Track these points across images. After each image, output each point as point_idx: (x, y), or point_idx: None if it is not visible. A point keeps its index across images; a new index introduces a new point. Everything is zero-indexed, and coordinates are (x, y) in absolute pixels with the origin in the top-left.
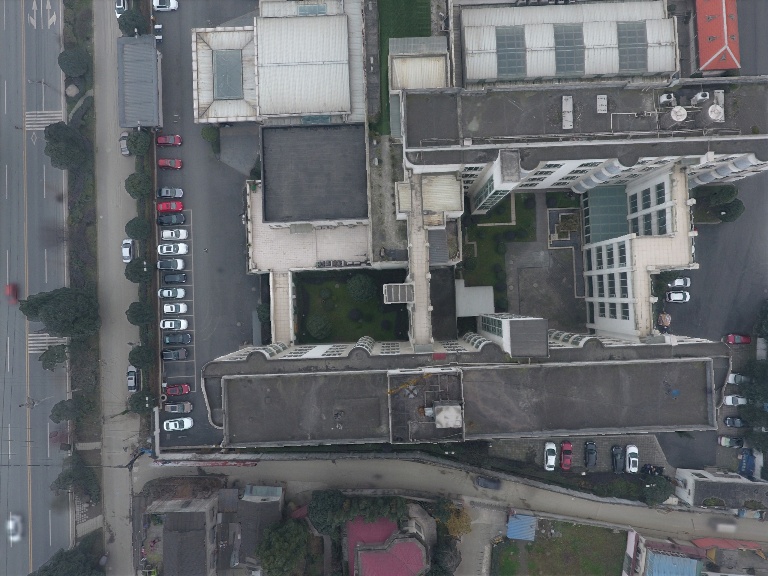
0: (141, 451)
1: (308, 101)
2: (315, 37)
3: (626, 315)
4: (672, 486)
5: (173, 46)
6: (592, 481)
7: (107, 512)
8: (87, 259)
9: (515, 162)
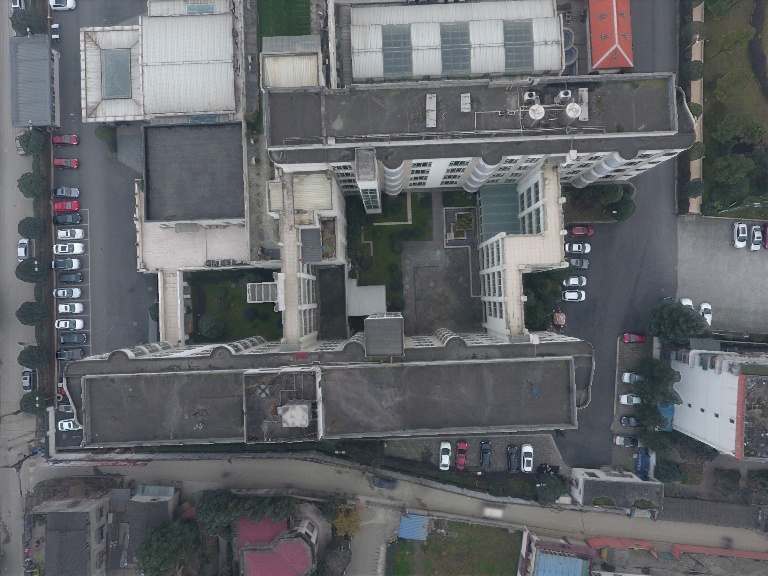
0: (34, 451)
1: None
2: (200, 36)
3: (501, 314)
4: (568, 485)
5: (71, 45)
6: (487, 480)
7: (3, 512)
8: None
9: (371, 161)
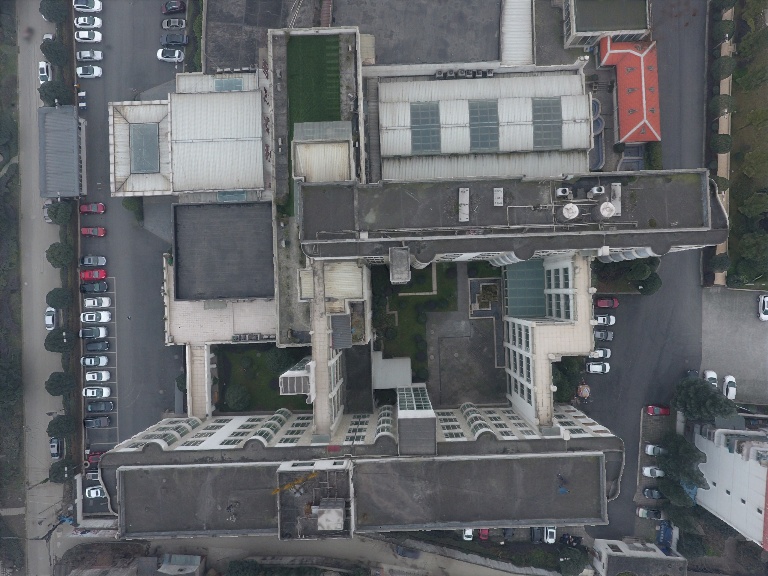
0: (62, 519)
1: (222, 177)
2: (229, 113)
3: (530, 400)
4: (590, 556)
5: (97, 113)
6: (510, 551)
7: None
8: (11, 326)
9: (405, 260)
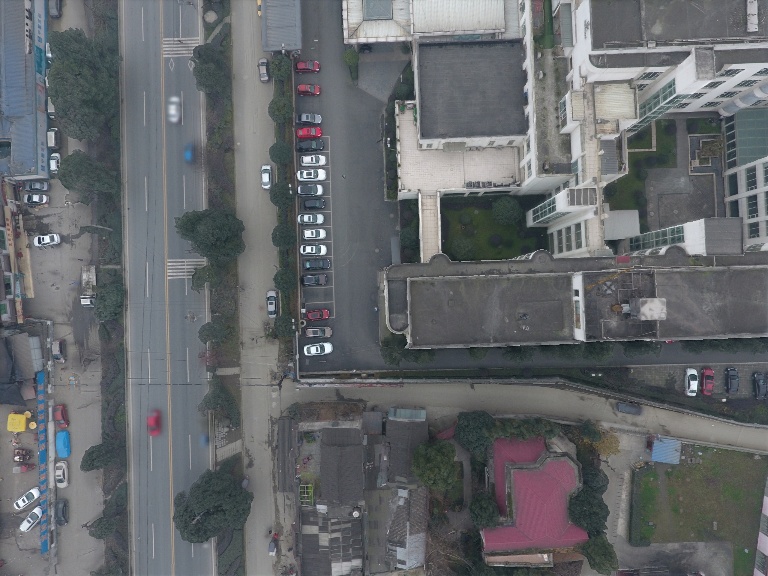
0: (284, 374)
1: None
2: None
3: None
4: None
5: None
6: (734, 407)
7: (246, 437)
8: (227, 185)
9: (709, 60)
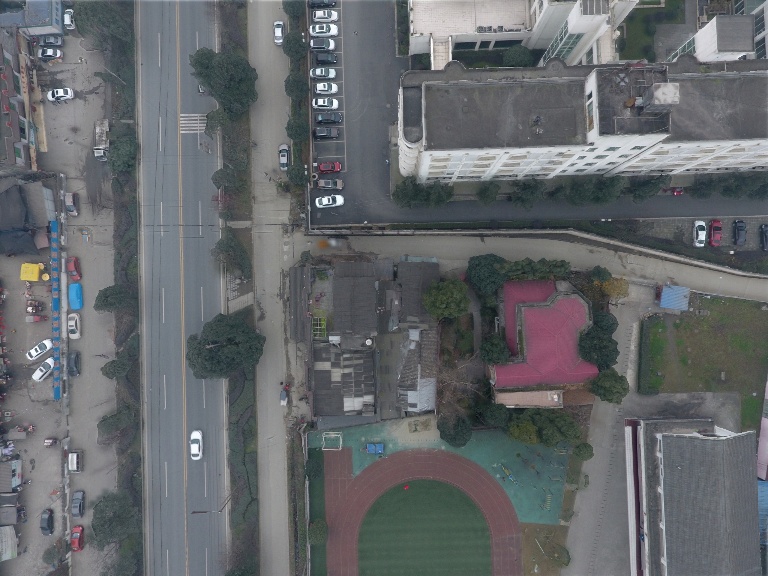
0: (296, 223)
1: None
2: None
3: None
4: None
5: None
6: (741, 258)
7: (257, 290)
8: (239, 39)
9: None
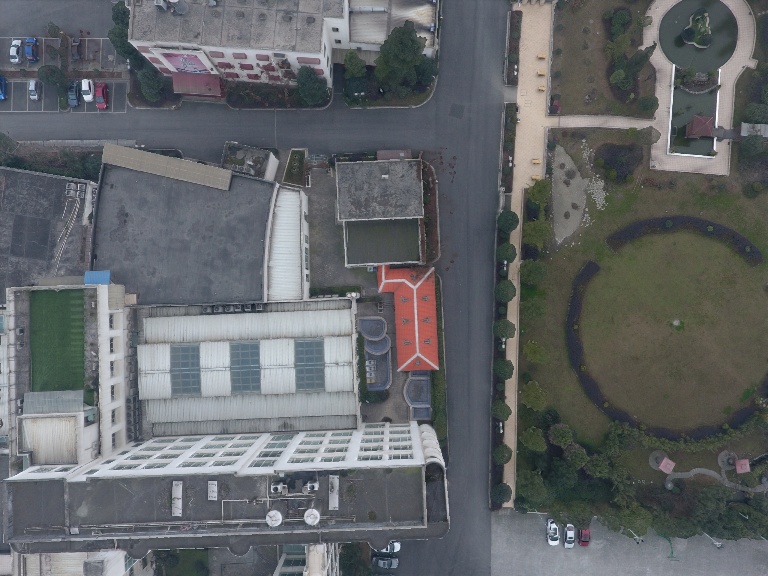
0: None
1: None
2: None
3: None
4: None
5: None
6: None
7: None
8: None
9: (100, 573)
